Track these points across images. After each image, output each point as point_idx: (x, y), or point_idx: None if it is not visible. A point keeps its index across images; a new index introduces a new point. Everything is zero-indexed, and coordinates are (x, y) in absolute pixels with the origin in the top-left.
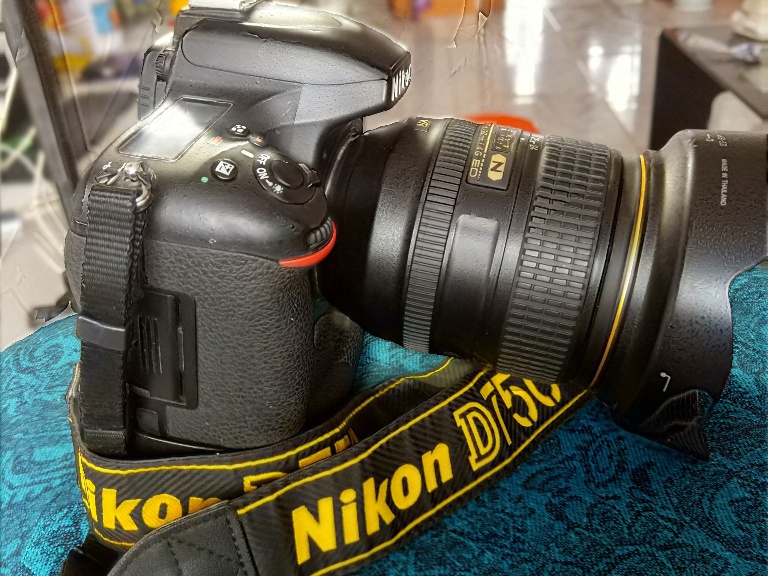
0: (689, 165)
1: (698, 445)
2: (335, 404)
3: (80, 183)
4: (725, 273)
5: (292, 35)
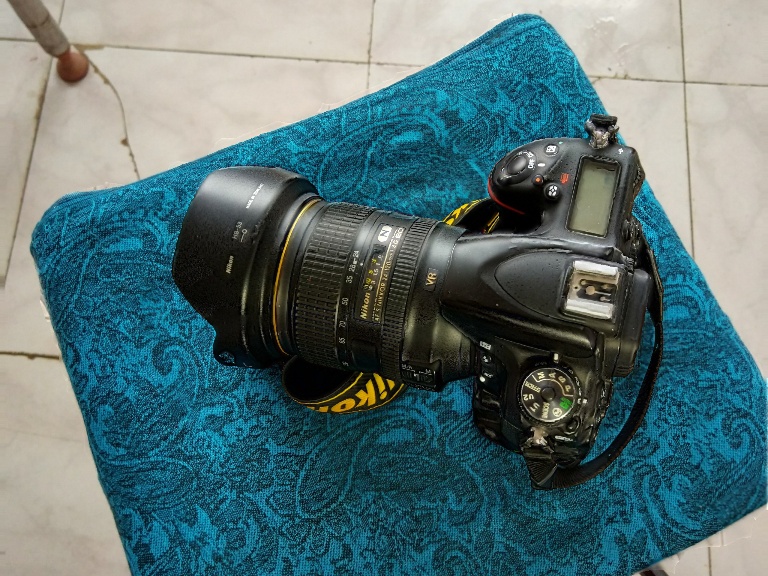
0: (267, 214)
1: None
2: None
3: (635, 152)
4: (274, 170)
5: (530, 244)
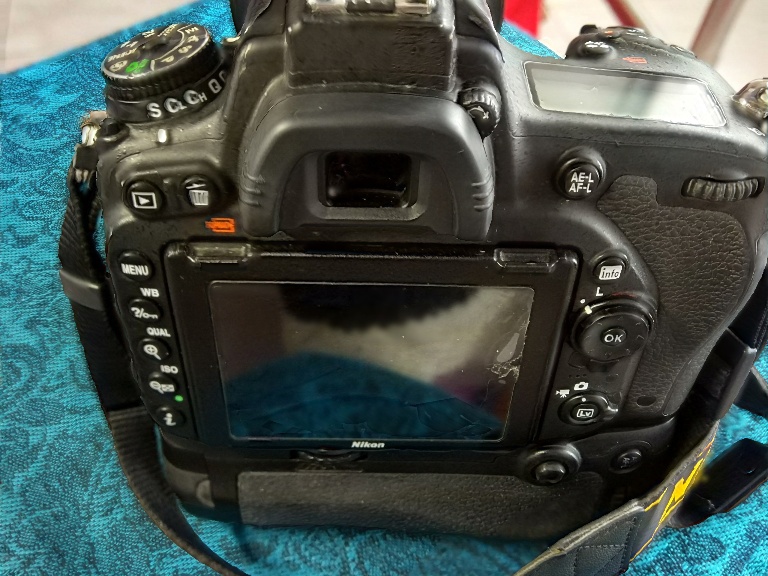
0: None
1: None
2: None
3: None
4: None
5: None
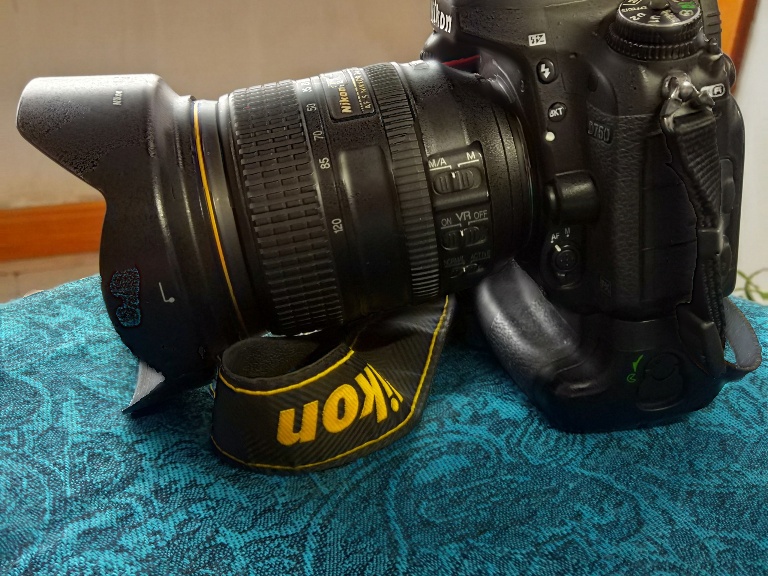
0: None
1: None
2: (471, 294)
3: None
4: None
5: None
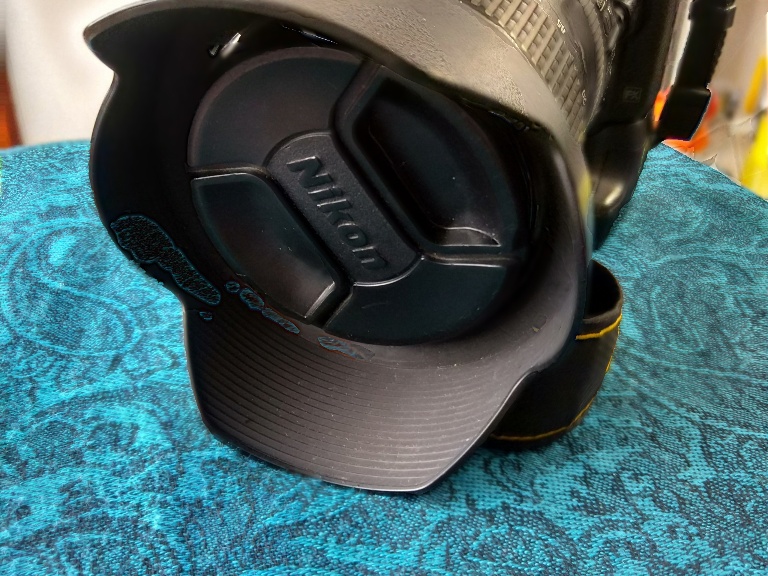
0: None
1: (248, 436)
2: None
3: None
4: None
5: None
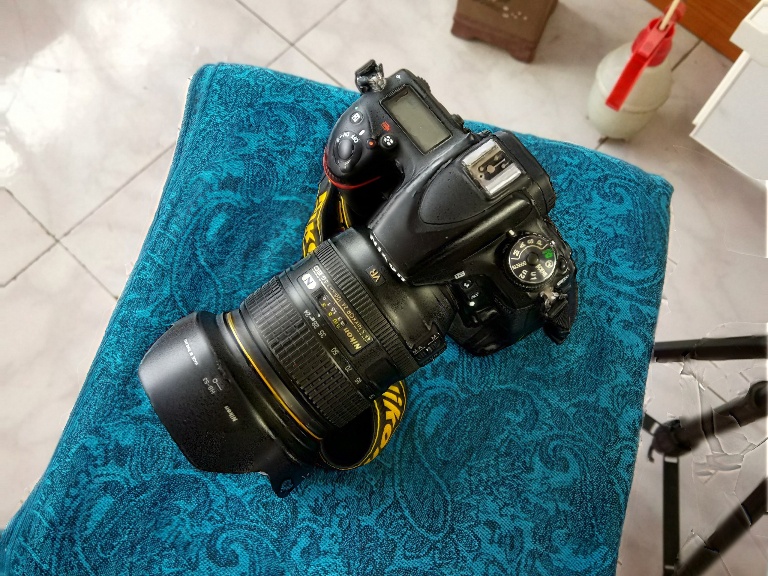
0: (215, 353)
1: None
2: None
3: None
4: None
5: None
